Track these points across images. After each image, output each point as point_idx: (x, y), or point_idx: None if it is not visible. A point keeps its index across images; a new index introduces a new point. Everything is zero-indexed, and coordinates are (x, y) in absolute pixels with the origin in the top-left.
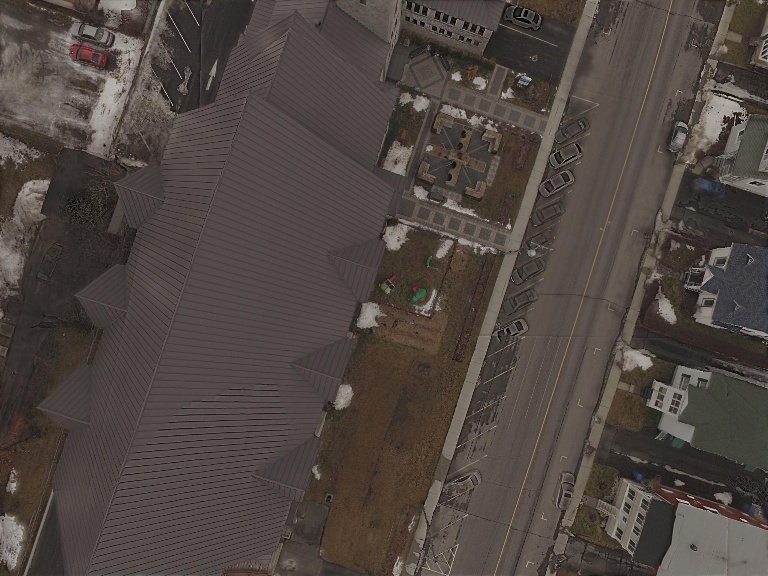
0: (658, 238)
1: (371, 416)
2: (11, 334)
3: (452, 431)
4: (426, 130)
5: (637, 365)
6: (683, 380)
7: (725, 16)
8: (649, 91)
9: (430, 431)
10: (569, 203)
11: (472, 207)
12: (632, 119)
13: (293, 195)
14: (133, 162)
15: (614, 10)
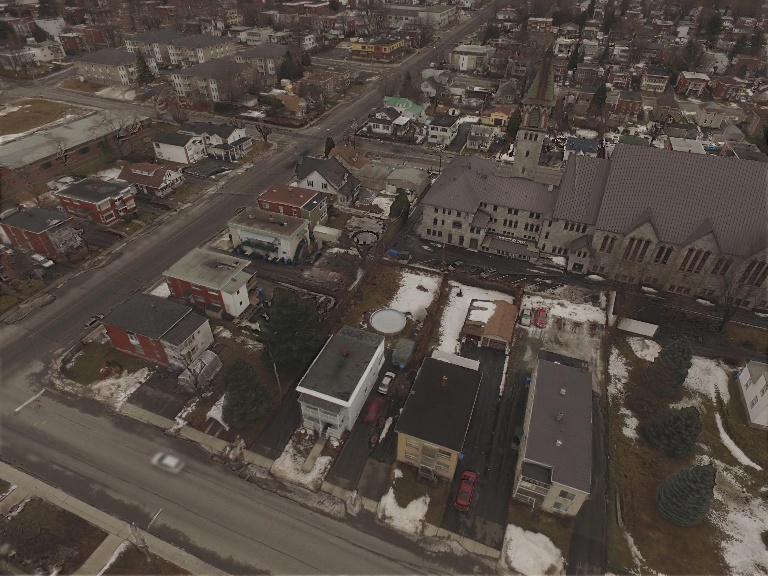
0: None
1: None
2: None
3: None
4: None
5: None
6: None
7: None
8: None
9: None
10: None
11: None
12: None
13: None
14: None
15: None
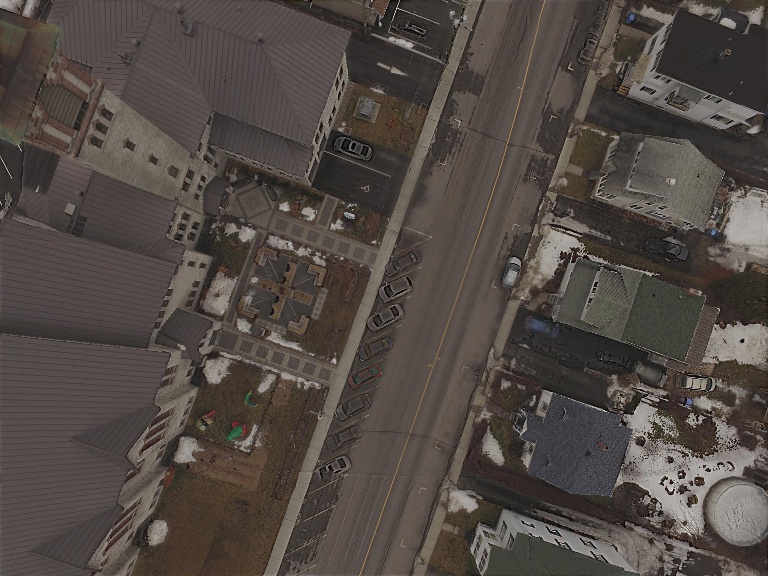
0: (488, 376)
1: (186, 553)
2: None
3: (269, 569)
4: (251, 261)
5: (462, 507)
6: (503, 528)
7: (566, 148)
8: (484, 224)
9: (246, 569)
10: (398, 338)
11: (297, 341)
12: (466, 253)
13: (6, 401)
14: None
15: (451, 140)
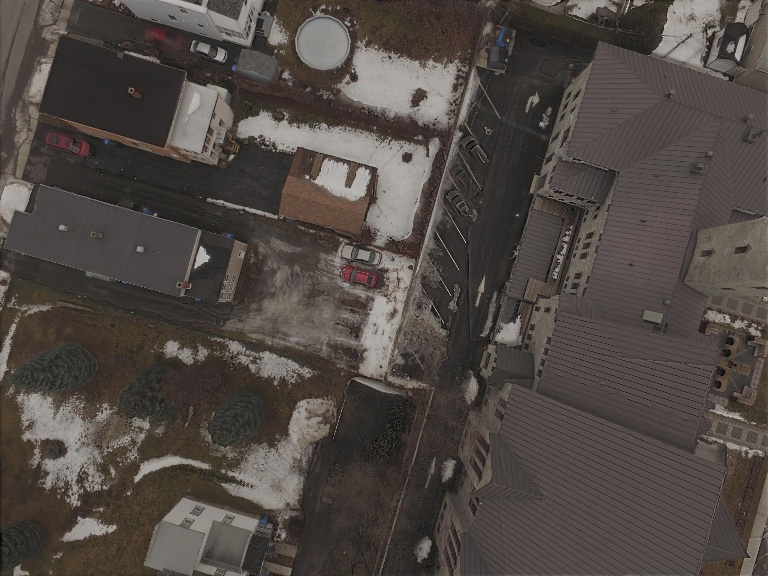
0: None
1: None
2: (294, 555)
3: None
4: None
5: None
6: None
7: None
8: None
9: None
10: None
11: (738, 411)
12: None
13: None
14: (409, 382)
15: None
